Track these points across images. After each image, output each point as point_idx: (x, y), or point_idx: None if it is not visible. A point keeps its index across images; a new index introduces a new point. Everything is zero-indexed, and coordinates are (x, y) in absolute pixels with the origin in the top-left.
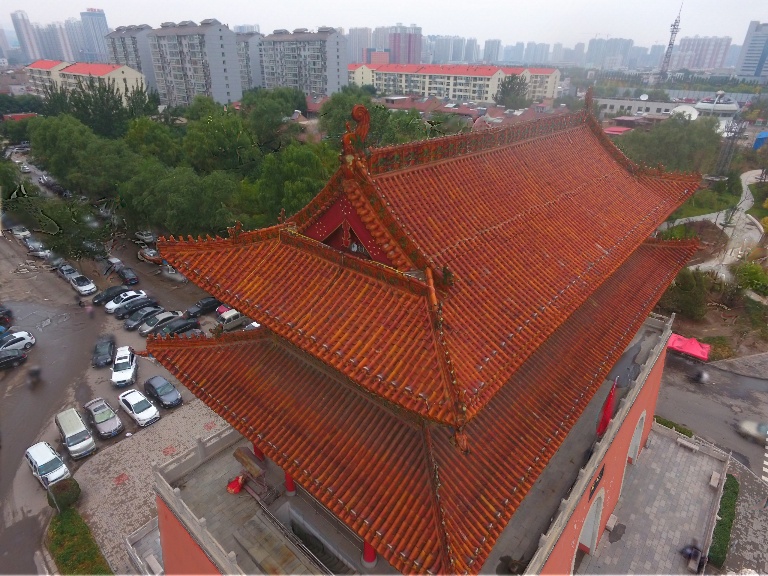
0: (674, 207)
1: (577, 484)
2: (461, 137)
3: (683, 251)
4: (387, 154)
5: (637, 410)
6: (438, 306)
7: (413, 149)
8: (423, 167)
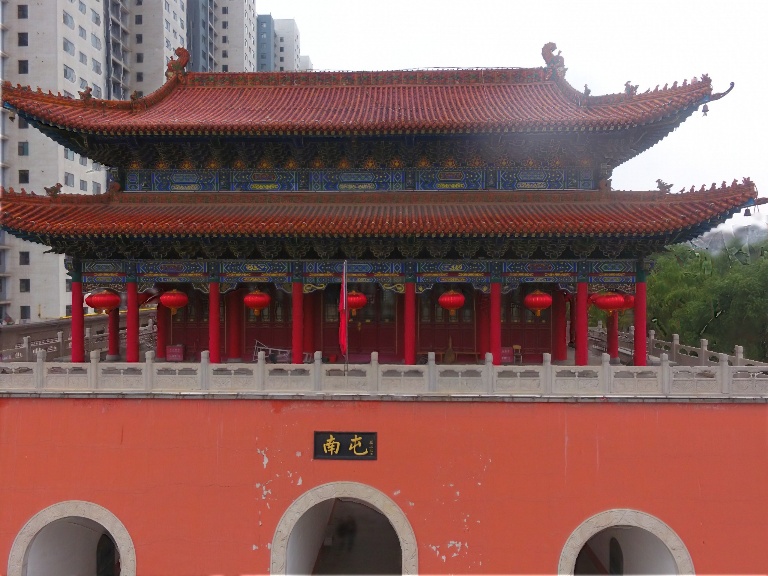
0: (610, 119)
1: (249, 364)
2: (285, 73)
3: (709, 204)
4: (203, 76)
5: (578, 468)
6: (106, 102)
7: (228, 75)
8: (237, 87)
